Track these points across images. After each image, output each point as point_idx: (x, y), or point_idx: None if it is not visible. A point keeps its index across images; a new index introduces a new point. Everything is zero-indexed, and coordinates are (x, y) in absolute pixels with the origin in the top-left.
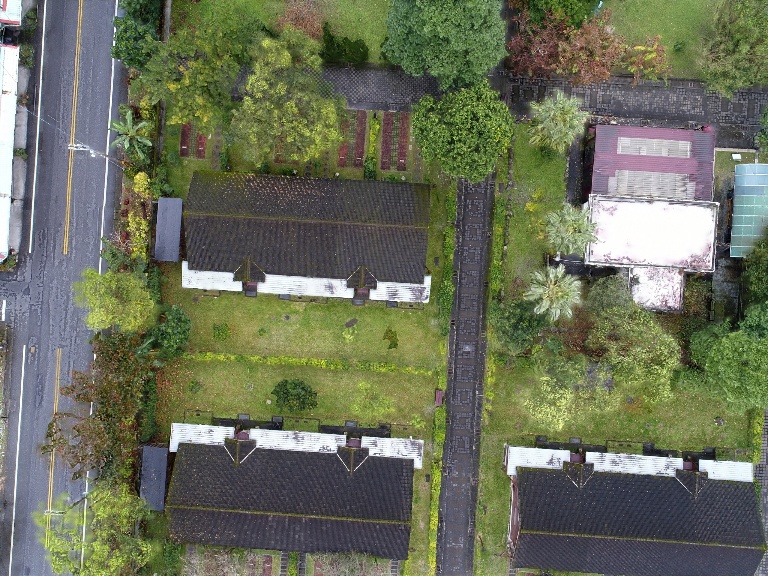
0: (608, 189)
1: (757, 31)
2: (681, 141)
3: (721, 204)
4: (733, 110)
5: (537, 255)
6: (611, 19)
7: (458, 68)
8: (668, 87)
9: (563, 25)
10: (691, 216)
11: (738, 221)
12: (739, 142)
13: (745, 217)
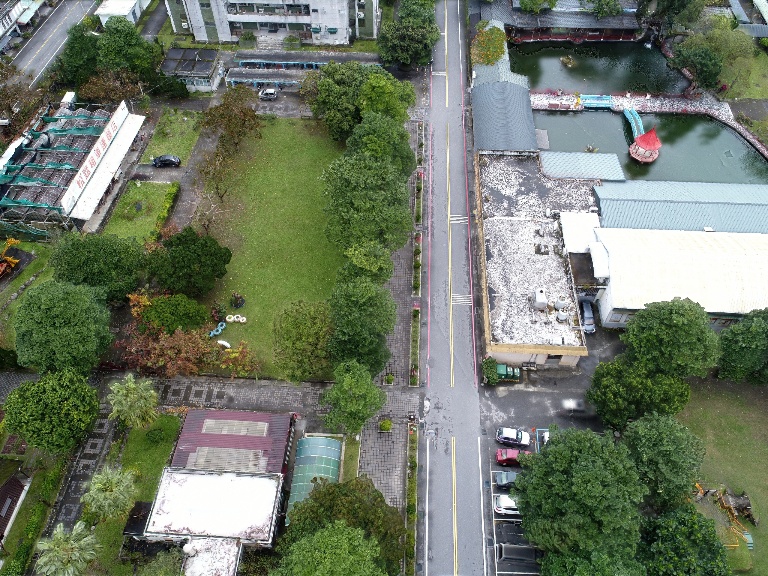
0: (187, 464)
1: (294, 331)
2: (259, 422)
3: (283, 475)
4: (328, 403)
5: (123, 535)
6: (232, 337)
7: (48, 357)
8: (274, 385)
9: (160, 332)
10: (255, 487)
11: (293, 490)
12: (332, 429)
13: (298, 485)
